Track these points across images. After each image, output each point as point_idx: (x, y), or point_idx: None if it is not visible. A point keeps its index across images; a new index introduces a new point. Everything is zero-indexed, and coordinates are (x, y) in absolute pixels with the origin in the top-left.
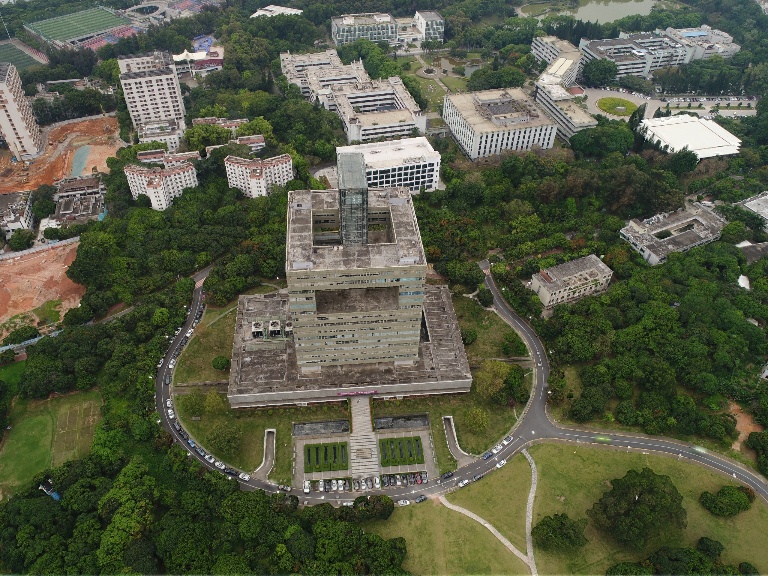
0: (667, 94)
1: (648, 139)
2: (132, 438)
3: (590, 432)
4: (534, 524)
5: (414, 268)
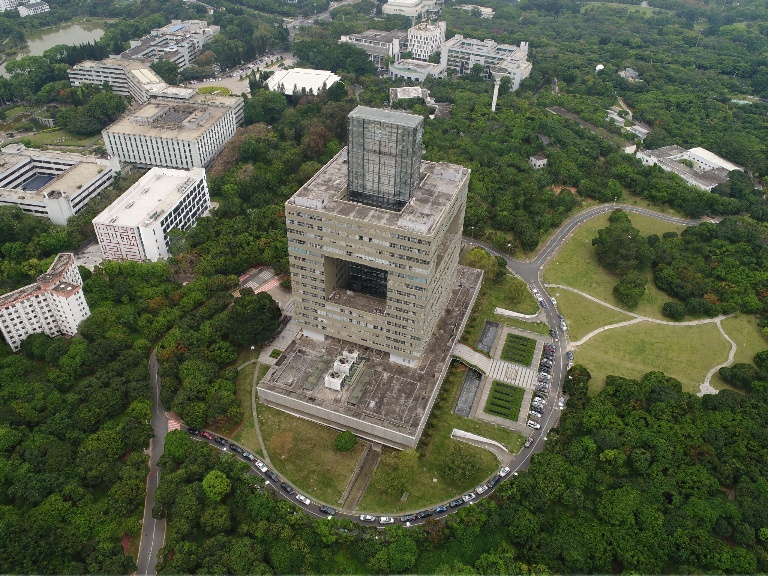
0: (226, 72)
1: (293, 91)
2: (403, 575)
3: (544, 249)
4: (612, 304)
5: (467, 177)
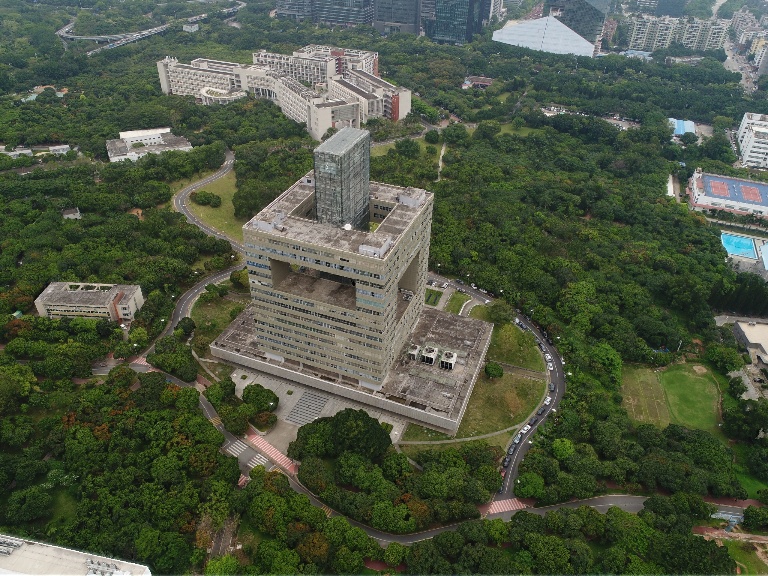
0: None
1: None
2: None
3: None
4: None
5: None
